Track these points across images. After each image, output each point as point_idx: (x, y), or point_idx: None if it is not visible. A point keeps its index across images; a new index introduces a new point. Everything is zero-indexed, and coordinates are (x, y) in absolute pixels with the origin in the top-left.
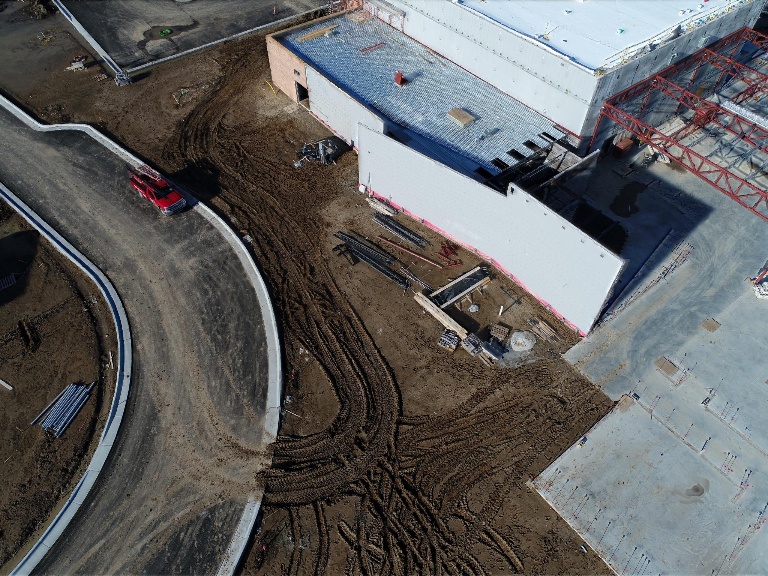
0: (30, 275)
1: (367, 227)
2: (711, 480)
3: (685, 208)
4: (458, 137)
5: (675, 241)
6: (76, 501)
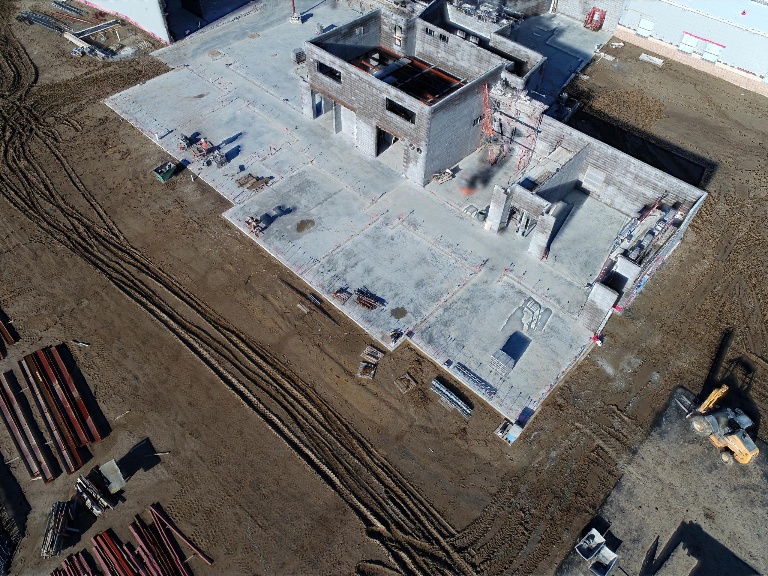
0: None
1: (46, 8)
2: (211, 92)
3: None
4: None
5: (256, 3)
6: None
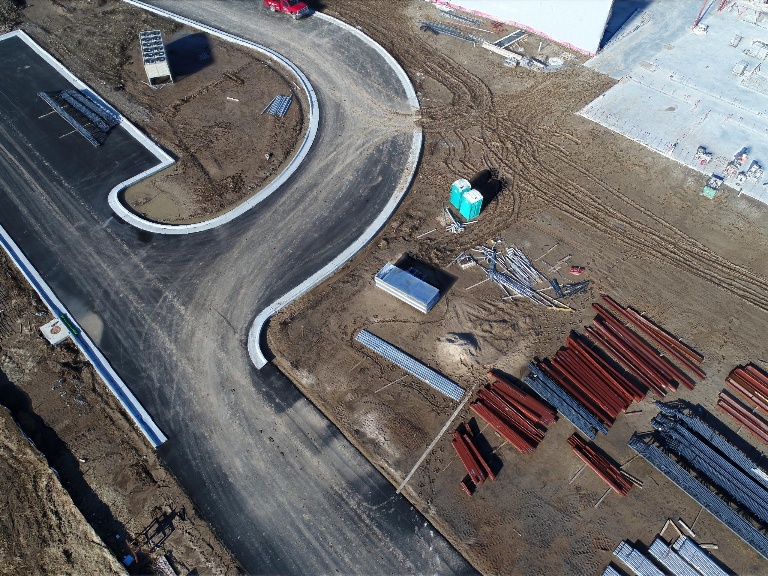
0: (216, 53)
1: (438, 18)
2: (678, 105)
3: None
4: None
5: (641, 13)
6: (310, 139)
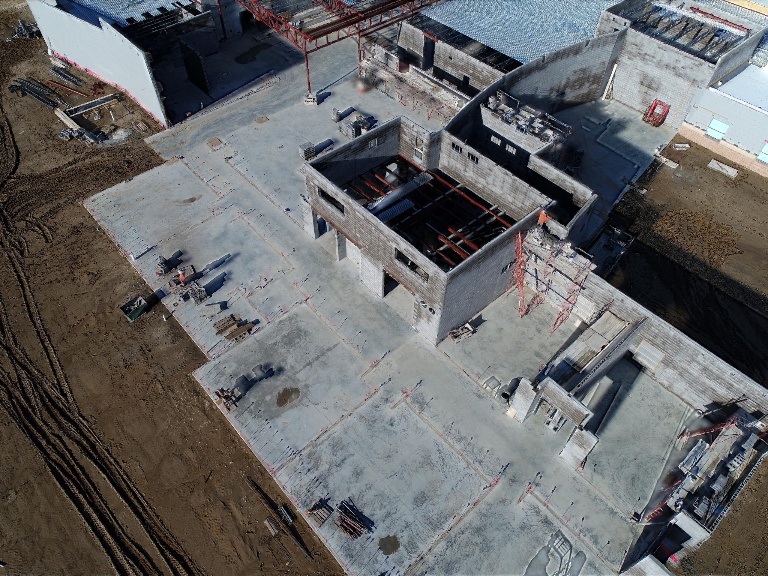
0: None
1: (43, 75)
2: (204, 195)
3: (291, 58)
4: (110, 6)
5: (270, 76)
6: None
